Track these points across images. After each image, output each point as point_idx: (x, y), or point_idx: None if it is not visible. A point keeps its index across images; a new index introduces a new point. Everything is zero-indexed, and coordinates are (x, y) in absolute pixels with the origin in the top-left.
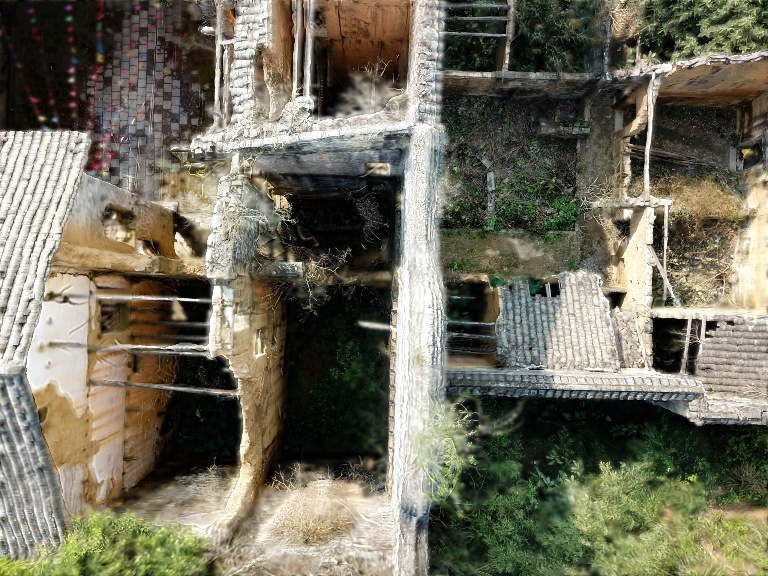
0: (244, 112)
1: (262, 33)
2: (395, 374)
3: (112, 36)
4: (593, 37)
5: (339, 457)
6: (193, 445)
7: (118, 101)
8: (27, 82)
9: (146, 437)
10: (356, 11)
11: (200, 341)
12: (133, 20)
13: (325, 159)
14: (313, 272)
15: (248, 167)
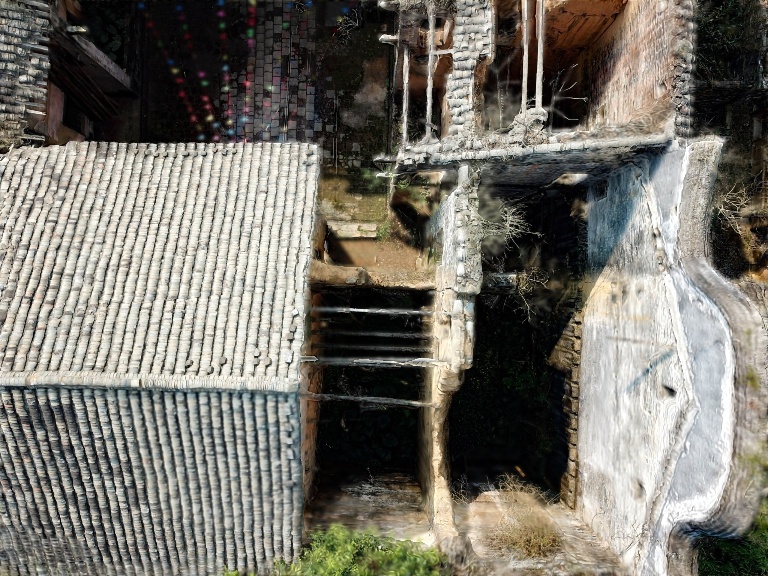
0: (465, 123)
1: (486, 43)
2: (579, 386)
3: (246, 42)
4: (747, 45)
5: (496, 468)
6: (342, 455)
7: (252, 107)
8: (160, 88)
9: (312, 448)
10: (559, 20)
11: (379, 352)
12: (267, 26)
13: (530, 170)
14: (525, 285)
15: (478, 179)
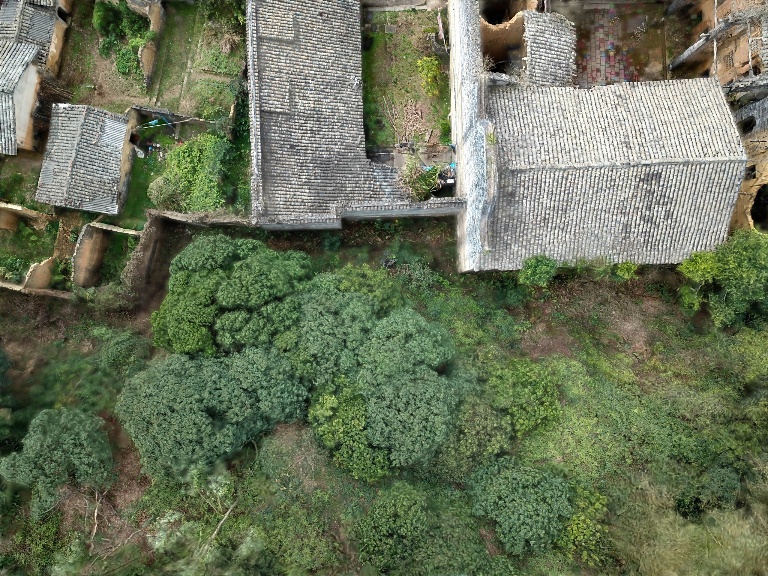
0: None
1: None
2: None
3: (585, 44)
4: None
5: None
6: None
7: (591, 78)
8: None
9: None
10: None
11: None
12: (596, 34)
13: None
14: None
15: None
